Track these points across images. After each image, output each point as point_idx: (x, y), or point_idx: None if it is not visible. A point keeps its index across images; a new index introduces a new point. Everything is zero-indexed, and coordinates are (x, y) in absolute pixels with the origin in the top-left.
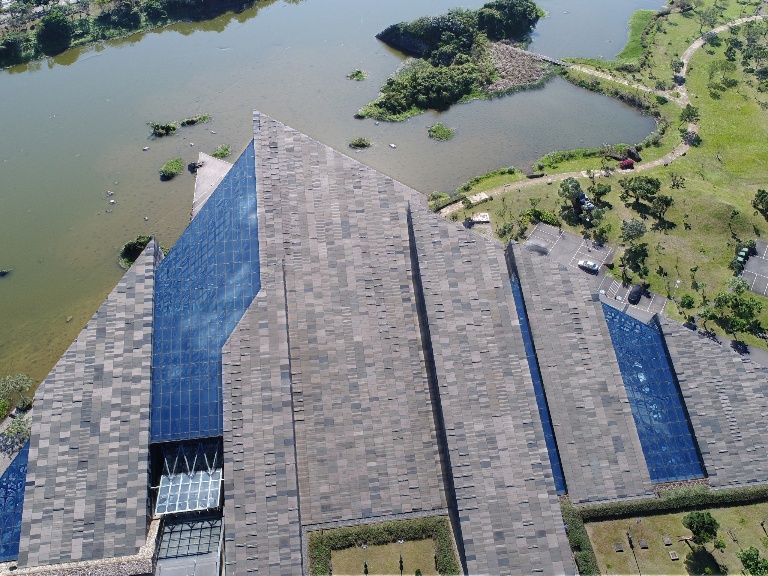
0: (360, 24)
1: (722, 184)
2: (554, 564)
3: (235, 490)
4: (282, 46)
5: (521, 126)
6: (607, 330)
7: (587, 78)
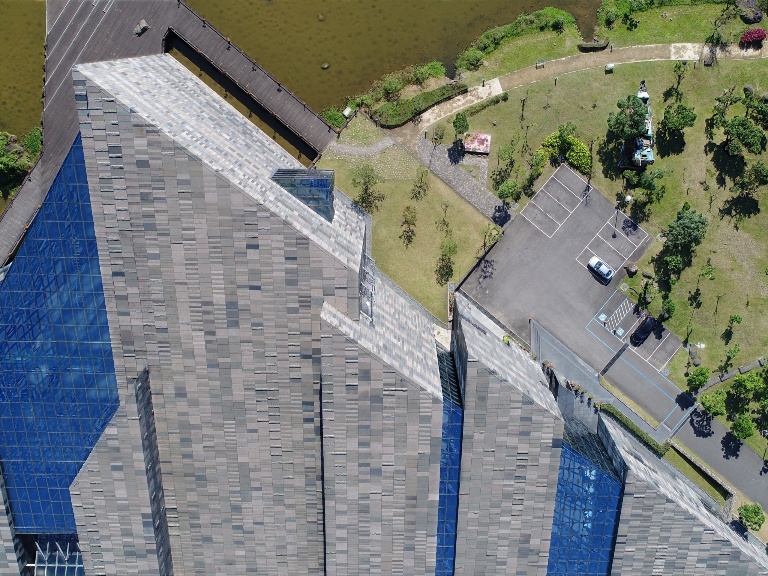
0: None
1: None
2: None
3: None
4: None
5: None
6: (555, 482)
7: None
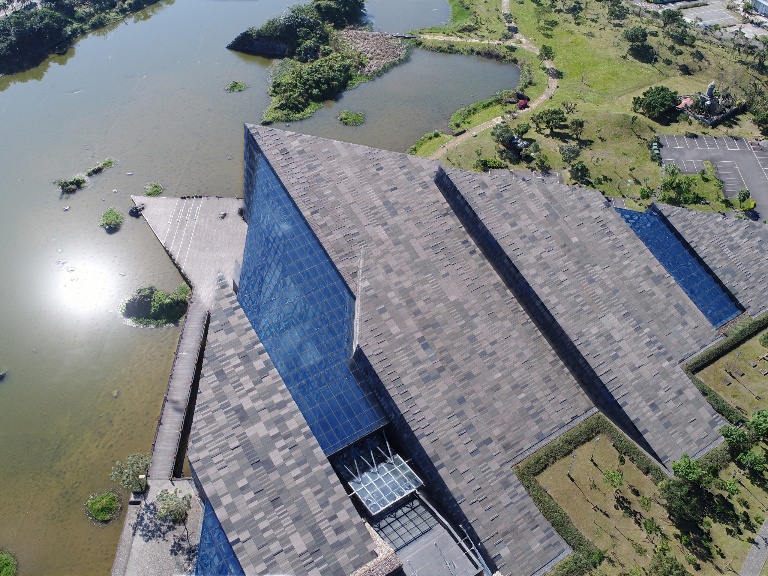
0: (202, 39)
1: (600, 102)
2: (700, 411)
3: (441, 459)
4: (136, 76)
5: (415, 96)
6: (628, 227)
7: (441, 44)
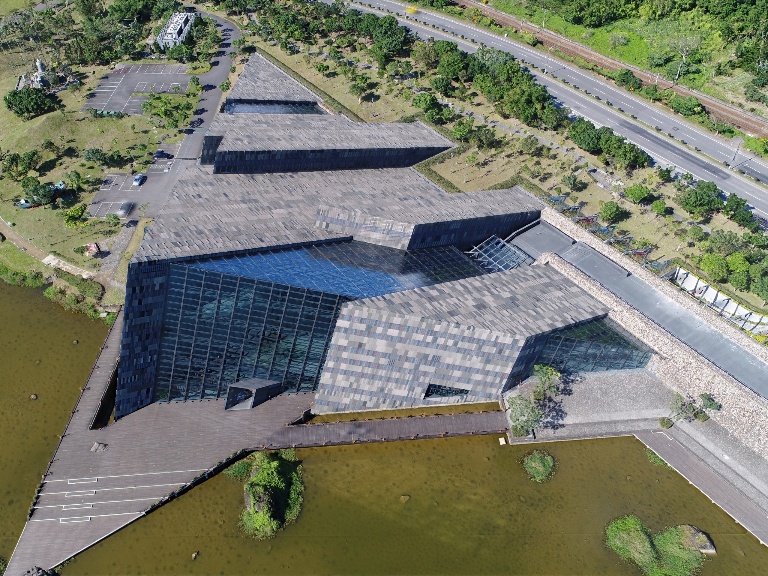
0: None
1: None
2: (411, 127)
3: (487, 212)
4: None
5: None
6: (253, 114)
7: None
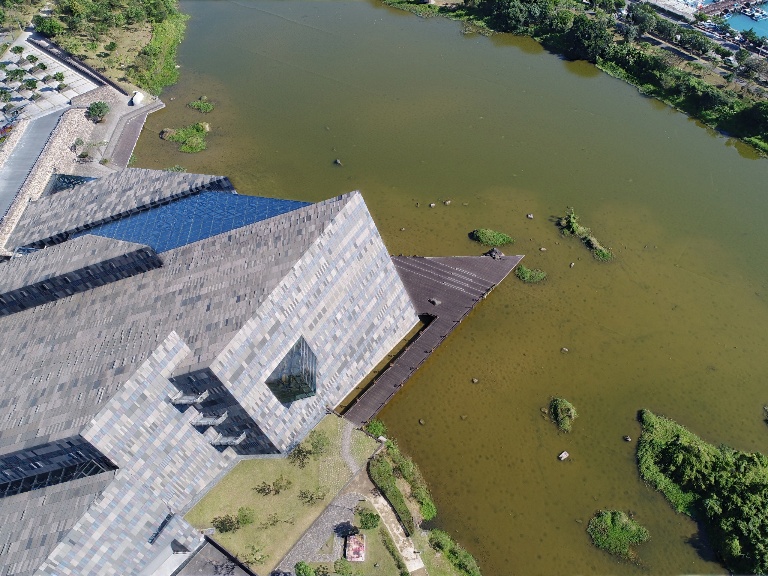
0: None
1: None
2: None
3: None
4: None
5: None
6: None
7: None
